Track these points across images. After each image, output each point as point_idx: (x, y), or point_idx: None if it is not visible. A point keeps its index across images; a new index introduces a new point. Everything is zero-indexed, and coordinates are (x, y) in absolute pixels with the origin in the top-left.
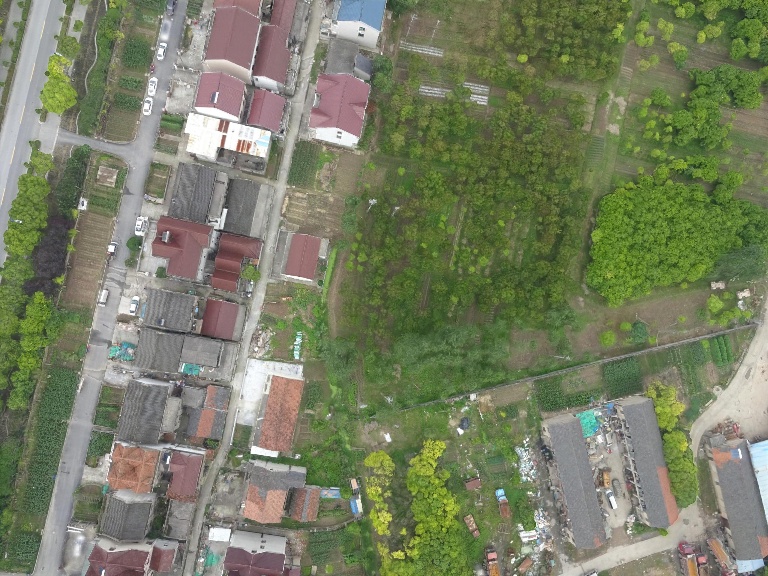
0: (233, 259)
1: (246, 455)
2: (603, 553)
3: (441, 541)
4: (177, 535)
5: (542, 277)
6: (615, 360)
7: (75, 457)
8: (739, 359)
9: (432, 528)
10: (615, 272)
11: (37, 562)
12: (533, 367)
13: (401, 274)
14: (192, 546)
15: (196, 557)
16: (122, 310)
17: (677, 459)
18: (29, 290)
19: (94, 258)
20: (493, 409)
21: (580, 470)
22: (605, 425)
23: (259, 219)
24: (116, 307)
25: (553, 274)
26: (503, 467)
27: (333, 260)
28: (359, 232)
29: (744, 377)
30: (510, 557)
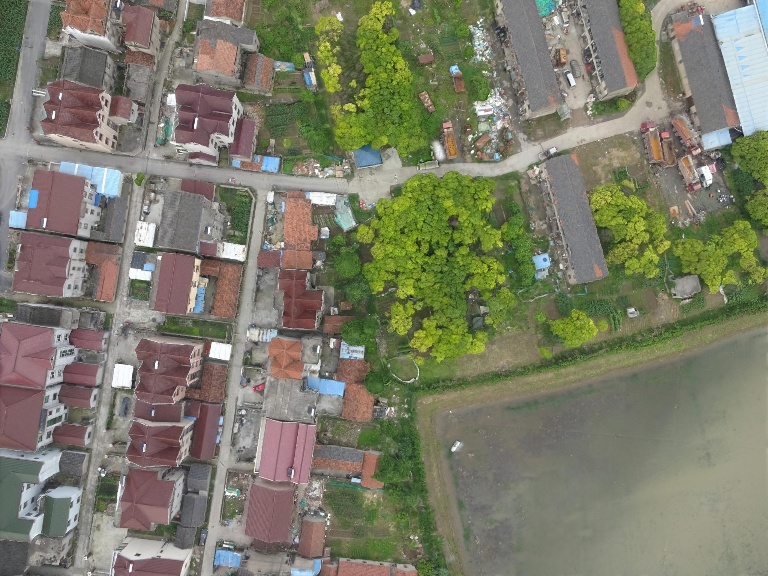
0: None
1: None
2: (563, 133)
3: (391, 91)
4: (136, 97)
5: None
6: None
7: (37, 33)
8: None
9: (381, 77)
10: None
11: (8, 128)
12: None
13: None
14: (153, 117)
15: None
16: None
17: (633, 20)
18: None
19: None
20: None
21: (532, 29)
22: (561, 6)
23: None
24: None
25: None
26: (457, 47)
27: None
28: None
29: None
30: (467, 133)
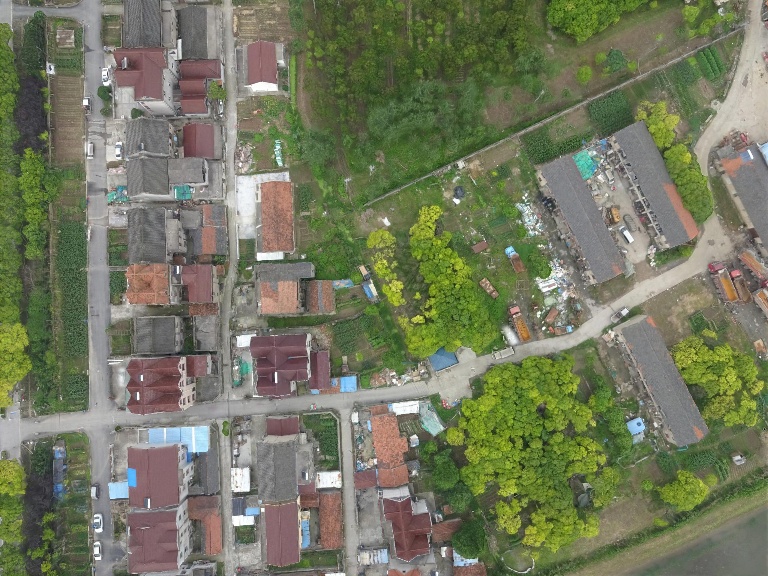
0: (196, 80)
1: (254, 264)
2: (630, 290)
3: (456, 297)
4: (207, 347)
5: (502, 28)
6: (599, 98)
7: (100, 300)
8: (732, 67)
9: (444, 286)
10: (574, 1)
11: (90, 399)
12: (513, 118)
13: (360, 58)
14: (225, 359)
15: (231, 368)
16: (109, 158)
17: (682, 171)
18: (19, 150)
19: (73, 117)
20: (484, 173)
21: (582, 203)
22: (603, 164)
23: (213, 41)
24: (104, 157)
25: (512, 21)
26: (508, 227)
27: (294, 67)
28: (310, 30)
29: (742, 85)
30: (534, 311)
